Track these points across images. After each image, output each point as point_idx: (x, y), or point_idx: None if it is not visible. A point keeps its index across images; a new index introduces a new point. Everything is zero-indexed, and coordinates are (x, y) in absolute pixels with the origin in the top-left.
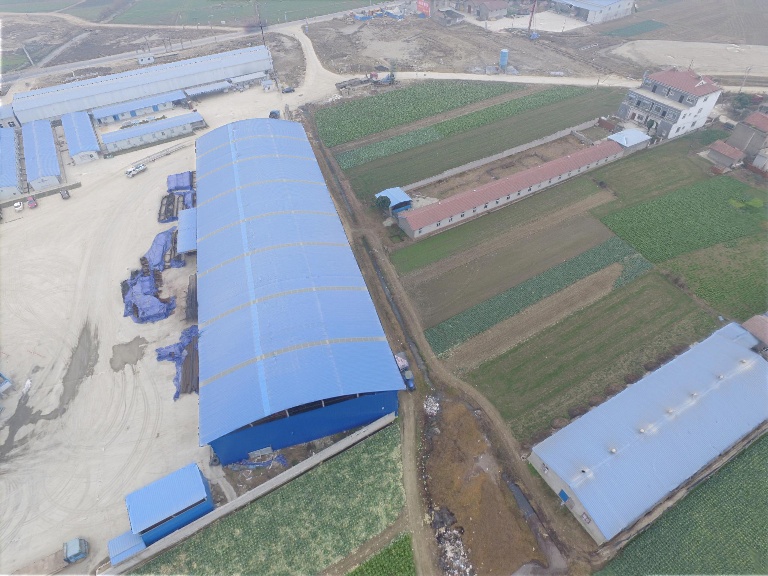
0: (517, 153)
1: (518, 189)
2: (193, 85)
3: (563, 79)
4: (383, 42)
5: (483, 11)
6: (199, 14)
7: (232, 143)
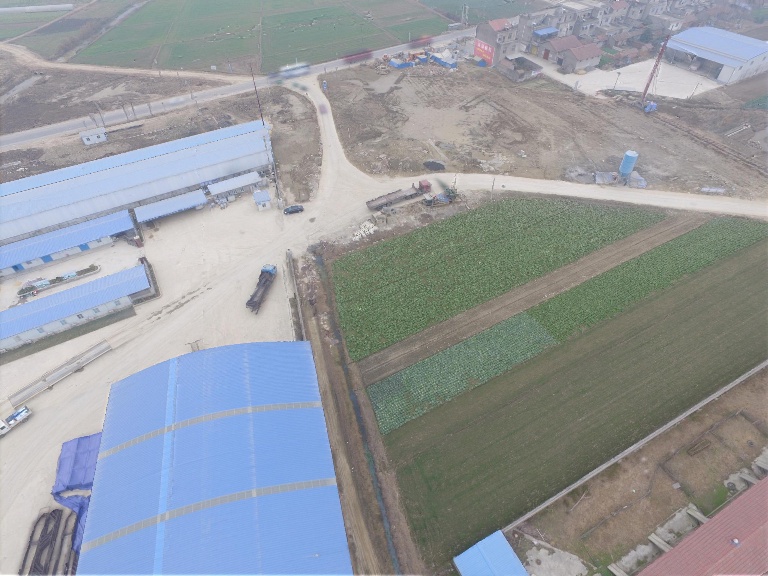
0: (704, 406)
1: (761, 570)
2: (150, 196)
3: (723, 201)
4: (431, 109)
5: (568, 60)
6: (186, 50)
7: (168, 434)
